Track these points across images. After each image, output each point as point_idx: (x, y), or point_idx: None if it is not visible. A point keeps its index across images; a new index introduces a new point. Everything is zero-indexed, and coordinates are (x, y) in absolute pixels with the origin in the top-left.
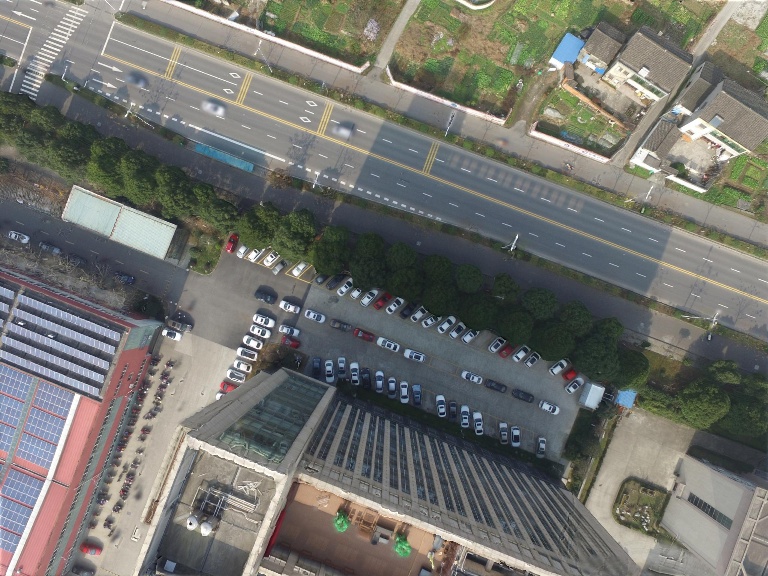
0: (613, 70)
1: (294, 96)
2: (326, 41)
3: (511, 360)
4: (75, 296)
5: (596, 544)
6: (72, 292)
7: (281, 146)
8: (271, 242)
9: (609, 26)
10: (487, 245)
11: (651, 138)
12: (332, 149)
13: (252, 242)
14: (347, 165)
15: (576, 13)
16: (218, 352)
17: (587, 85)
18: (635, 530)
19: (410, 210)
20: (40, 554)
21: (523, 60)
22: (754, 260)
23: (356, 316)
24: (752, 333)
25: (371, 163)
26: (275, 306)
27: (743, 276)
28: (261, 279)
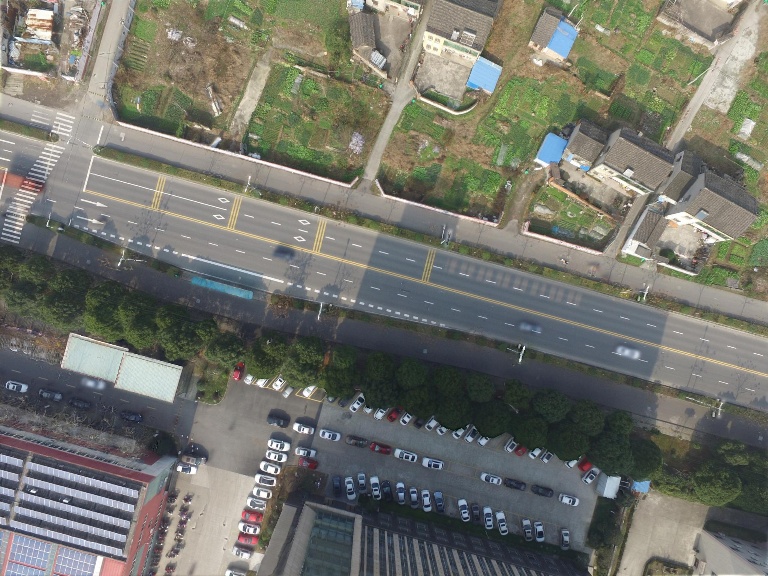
0: (598, 169)
1: (286, 216)
2: (312, 158)
3: (527, 457)
4: (84, 448)
5: None
6: (80, 443)
7: (278, 267)
8: (280, 371)
9: (590, 126)
10: (492, 346)
11: (640, 229)
12: (330, 266)
13: (261, 376)
14: (346, 280)
15: (556, 111)
16: (236, 481)
17: (573, 180)
18: None
19: (413, 319)
20: None
21: (509, 161)
22: (748, 335)
23: (371, 430)
24: (753, 406)
25: (370, 276)
26: (289, 428)
27: (739, 352)
28: (272, 403)
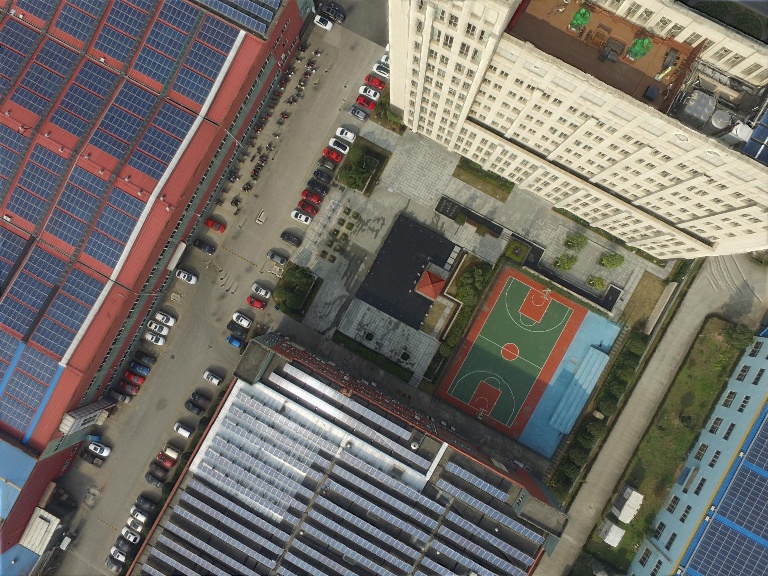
0: None
1: None
2: None
3: None
4: None
5: (723, 279)
6: None
7: None
8: None
9: None
10: None
11: None
12: None
13: None
14: None
15: None
16: (366, 47)
17: None
18: (767, 265)
19: None
20: (184, 186)
21: None
22: None
23: None
24: None
25: None
26: None
27: None
28: None
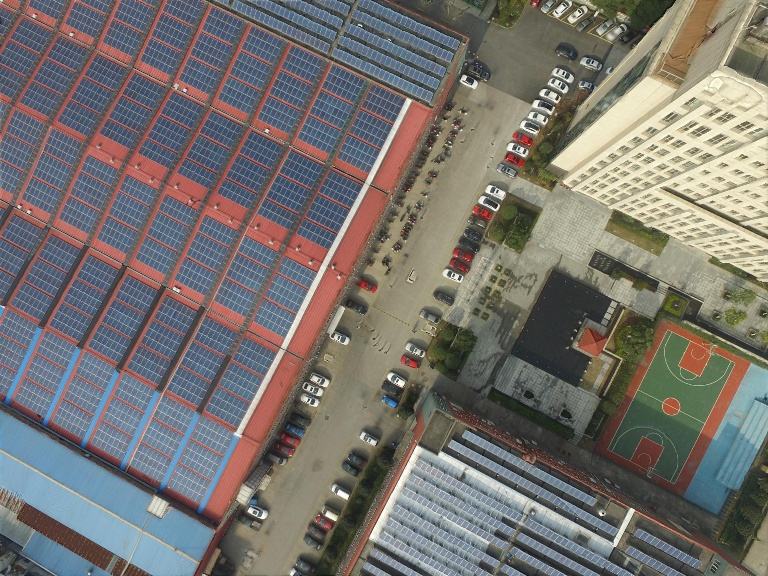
0: None
1: None
2: None
3: None
4: None
5: None
6: None
7: None
8: None
9: None
10: None
11: None
12: None
13: None
14: None
15: None
16: (512, 104)
17: None
18: None
19: None
20: (354, 254)
21: None
22: None
23: None
24: None
25: None
26: (574, 63)
27: None
28: (562, 36)
